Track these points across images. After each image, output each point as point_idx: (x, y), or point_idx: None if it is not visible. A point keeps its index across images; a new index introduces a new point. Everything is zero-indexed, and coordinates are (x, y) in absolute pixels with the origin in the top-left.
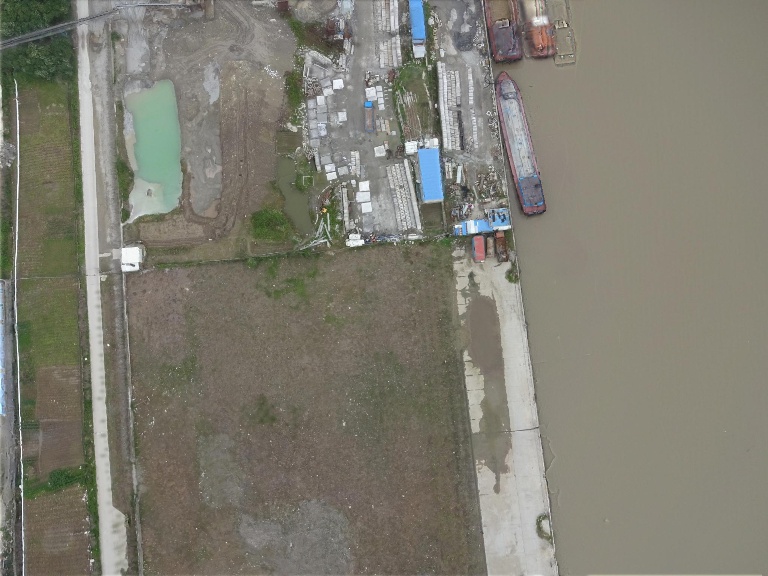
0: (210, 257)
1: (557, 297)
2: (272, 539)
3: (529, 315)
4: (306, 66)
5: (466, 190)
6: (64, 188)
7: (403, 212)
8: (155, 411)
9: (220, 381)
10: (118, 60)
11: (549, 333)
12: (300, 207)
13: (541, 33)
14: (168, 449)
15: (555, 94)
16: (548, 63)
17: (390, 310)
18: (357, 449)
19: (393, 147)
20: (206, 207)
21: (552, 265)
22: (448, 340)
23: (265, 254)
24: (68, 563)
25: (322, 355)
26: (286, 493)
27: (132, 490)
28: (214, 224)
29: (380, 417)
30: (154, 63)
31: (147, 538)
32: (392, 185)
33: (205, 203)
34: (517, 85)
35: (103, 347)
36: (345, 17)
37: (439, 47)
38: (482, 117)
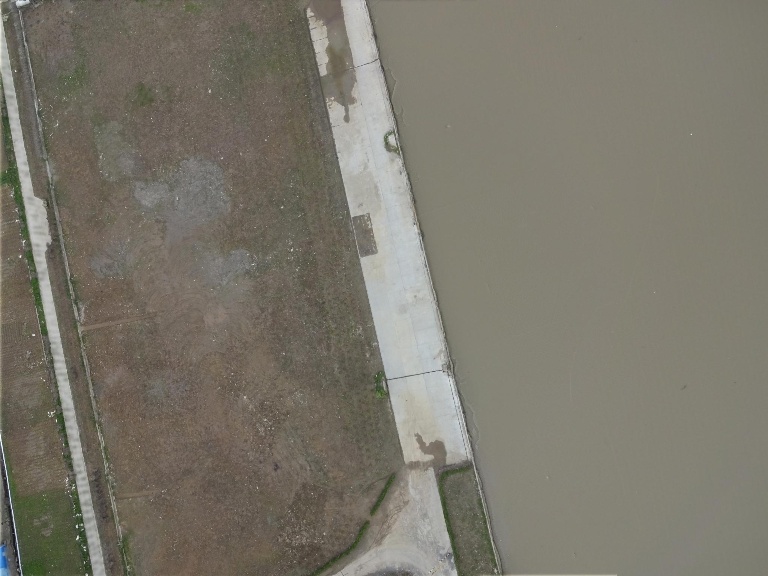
0: None
1: None
2: (162, 197)
3: None
4: None
5: None
6: None
7: None
8: (58, 115)
9: (105, 79)
10: None
11: None
12: None
13: None
14: (71, 143)
15: None
16: None
17: None
18: (223, 110)
19: None
20: None
21: None
22: (292, 2)
23: None
24: (6, 246)
25: (186, 39)
26: (168, 158)
27: (48, 181)
28: None
29: (239, 79)
30: None
31: (64, 216)
32: None
33: None
34: None
35: (12, 74)
36: None
37: None
38: None
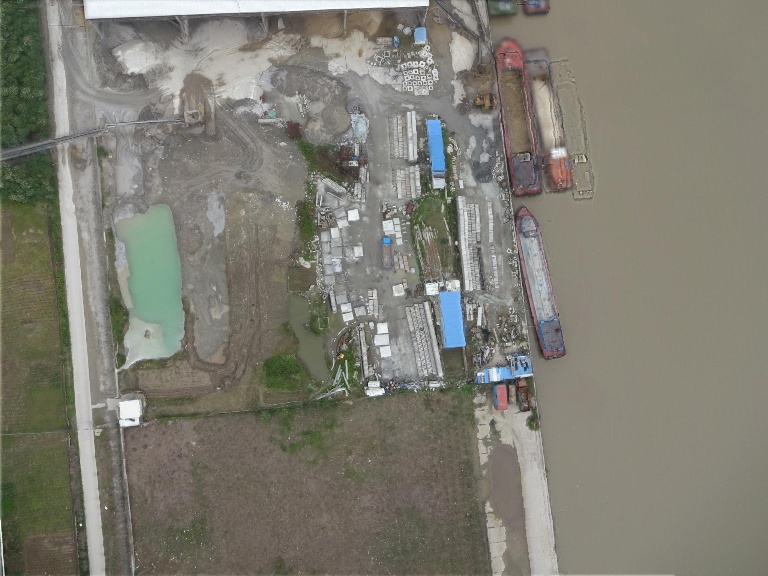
0: (218, 408)
1: (576, 444)
2: None
3: (548, 462)
4: (318, 194)
5: (487, 333)
6: (47, 329)
7: (423, 357)
8: None
9: (233, 544)
10: (106, 181)
11: (568, 481)
12: (315, 350)
13: (560, 165)
14: None
15: (573, 230)
16: (566, 197)
17: (411, 462)
18: None
19: (412, 285)
20: (212, 352)
21: (571, 411)
22: (470, 491)
23: (279, 404)
24: None
25: (342, 512)
26: None
27: None
28: (222, 372)
29: (403, 575)
30: (149, 186)
31: None
32: (412, 327)
33: (211, 347)
34: (535, 218)
35: (100, 510)
36: (359, 140)
37: (458, 177)
38: (502, 255)
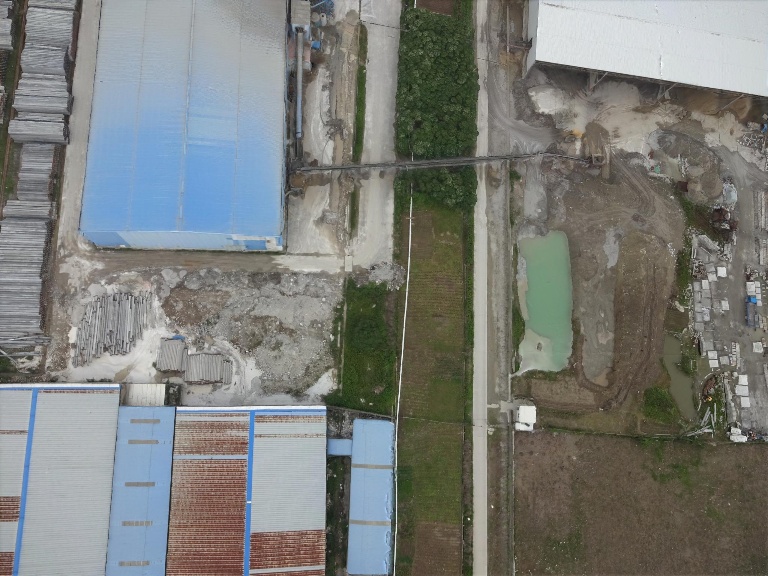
0: (600, 428)
1: None
2: None
3: None
4: (693, 247)
5: None
6: (454, 325)
7: None
8: None
9: (604, 564)
10: (517, 201)
11: None
12: (683, 389)
13: None
14: None
15: None
16: None
17: (765, 512)
18: None
19: None
20: (597, 374)
21: None
22: None
23: (652, 434)
24: None
25: (703, 550)
26: None
27: None
28: (607, 394)
29: None
30: (554, 213)
31: None
32: None
33: (597, 369)
34: None
35: (487, 508)
36: (729, 207)
37: None
38: None
